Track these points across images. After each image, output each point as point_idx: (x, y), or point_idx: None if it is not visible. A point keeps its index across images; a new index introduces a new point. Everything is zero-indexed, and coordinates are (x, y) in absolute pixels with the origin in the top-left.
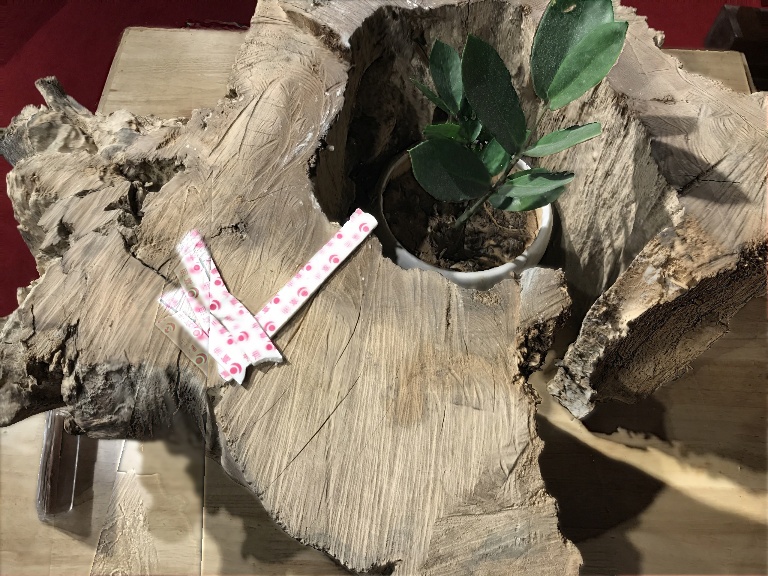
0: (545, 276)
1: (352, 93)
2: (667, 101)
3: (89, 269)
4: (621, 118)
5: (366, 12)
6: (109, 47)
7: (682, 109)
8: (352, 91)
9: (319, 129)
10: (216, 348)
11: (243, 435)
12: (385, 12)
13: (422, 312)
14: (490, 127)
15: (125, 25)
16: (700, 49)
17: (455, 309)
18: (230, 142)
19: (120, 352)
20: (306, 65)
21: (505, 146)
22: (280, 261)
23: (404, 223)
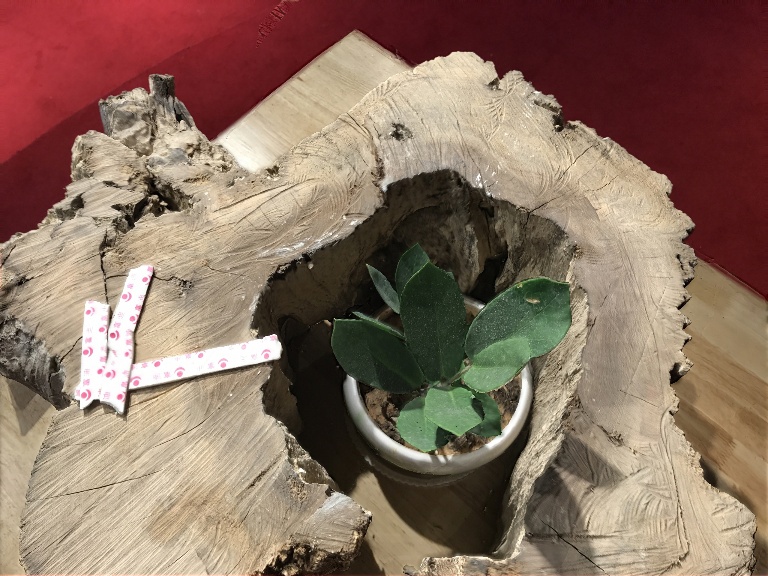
0: (350, 511)
1: (385, 224)
2: (614, 438)
3: (68, 245)
4: (560, 420)
5: (430, 167)
6: (328, 39)
7: (620, 457)
8: (385, 223)
9: (311, 244)
10: (88, 369)
11: (53, 448)
12: (452, 175)
13: (244, 458)
14: (416, 348)
15: (356, 27)
16: None
17: (267, 477)
18: (238, 210)
19: (36, 322)
20: (350, 181)
21: (426, 371)
22: (188, 334)
23: None
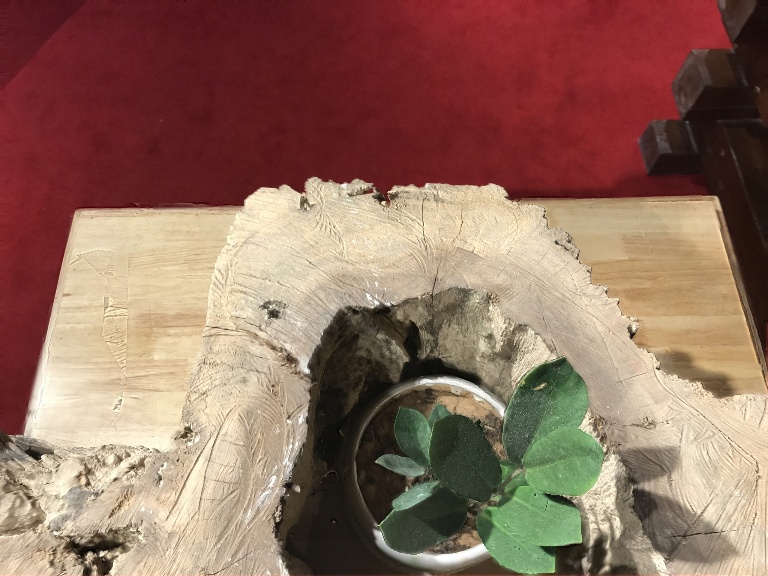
0: None
1: (316, 392)
2: (647, 425)
3: None
4: (600, 443)
5: (324, 320)
6: (59, 237)
7: (663, 435)
8: None
9: (283, 470)
10: None
11: None
12: (345, 311)
13: None
14: (464, 490)
15: (75, 207)
16: (671, 195)
17: None
18: (188, 498)
19: None
20: (264, 386)
21: (481, 498)
22: None
23: (380, 480)
